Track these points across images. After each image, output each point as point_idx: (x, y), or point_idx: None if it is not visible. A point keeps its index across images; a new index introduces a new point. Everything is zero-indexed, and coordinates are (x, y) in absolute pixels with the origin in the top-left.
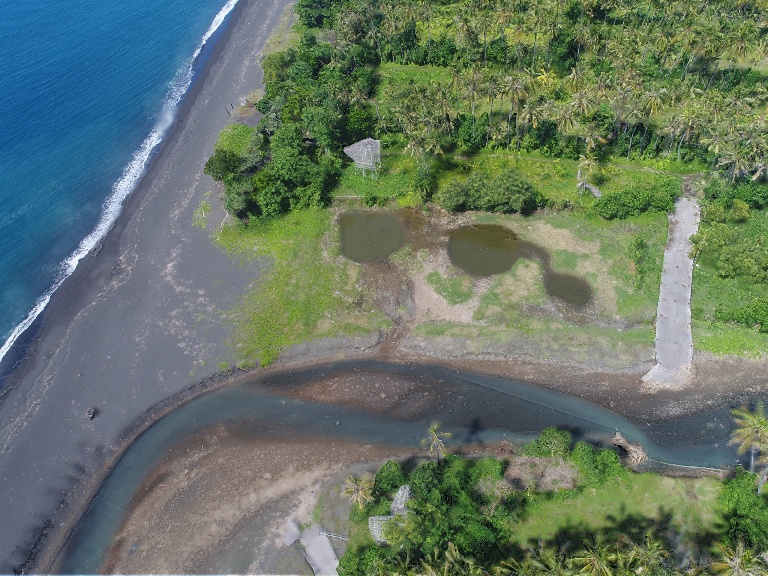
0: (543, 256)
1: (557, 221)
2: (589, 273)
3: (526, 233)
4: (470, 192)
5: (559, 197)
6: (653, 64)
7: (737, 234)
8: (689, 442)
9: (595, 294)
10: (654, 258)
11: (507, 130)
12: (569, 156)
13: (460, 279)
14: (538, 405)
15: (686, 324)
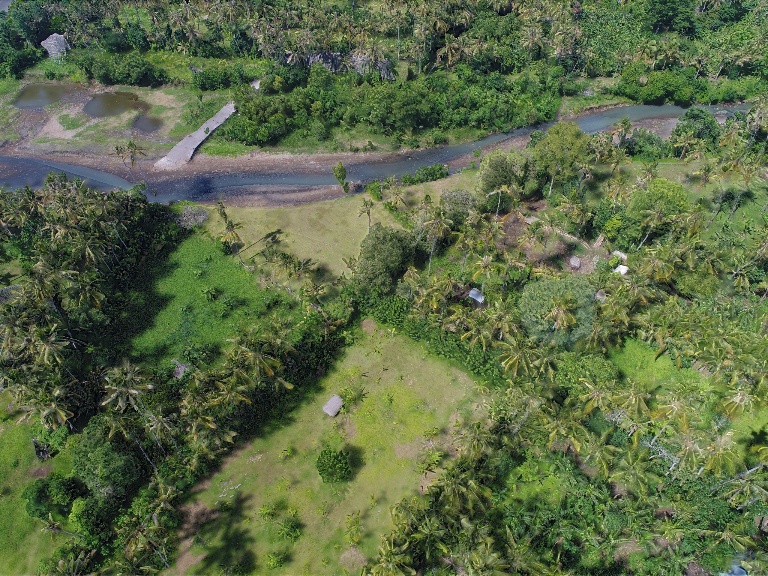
0: (146, 109)
1: (170, 91)
2: (167, 117)
3: (145, 97)
4: (109, 68)
5: (179, 77)
6: (287, 1)
7: (256, 91)
8: (158, 193)
9: (162, 127)
10: (211, 109)
11: (160, 35)
12: (201, 55)
13: (80, 118)
14: (81, 176)
15: (200, 139)
